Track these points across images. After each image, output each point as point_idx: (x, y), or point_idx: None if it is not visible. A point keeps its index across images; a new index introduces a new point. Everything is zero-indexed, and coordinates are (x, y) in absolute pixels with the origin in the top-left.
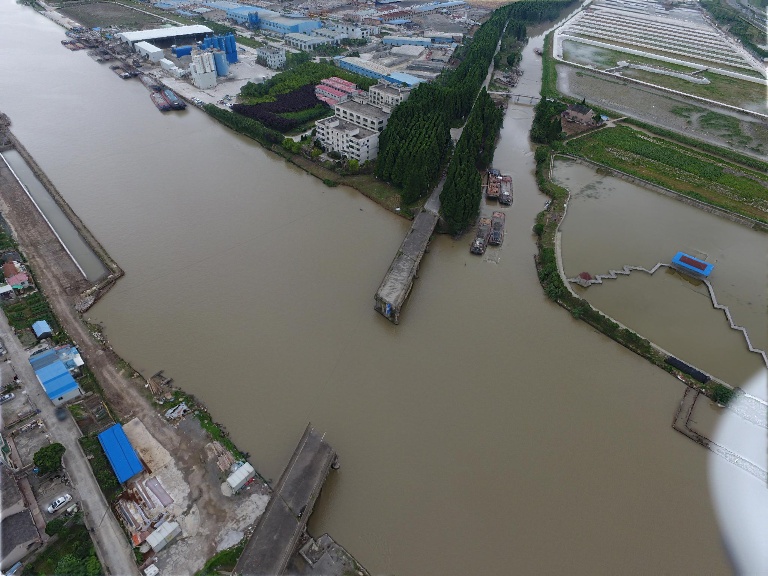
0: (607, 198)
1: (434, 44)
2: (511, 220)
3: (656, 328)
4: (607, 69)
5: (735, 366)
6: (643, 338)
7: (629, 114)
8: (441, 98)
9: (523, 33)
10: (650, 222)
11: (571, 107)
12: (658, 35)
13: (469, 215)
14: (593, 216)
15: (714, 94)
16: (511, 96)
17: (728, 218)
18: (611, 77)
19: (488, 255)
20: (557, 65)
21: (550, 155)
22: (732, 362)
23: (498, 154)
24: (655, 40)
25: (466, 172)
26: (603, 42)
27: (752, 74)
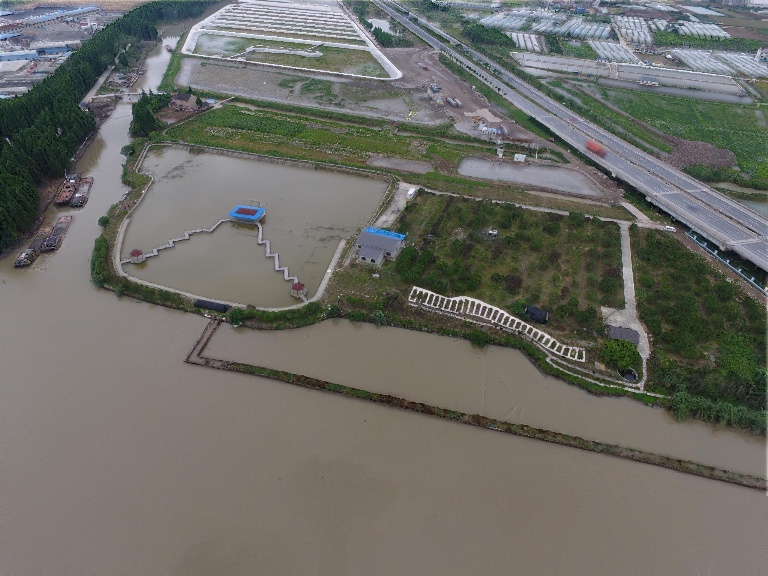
0: (192, 174)
1: (42, 56)
2: (78, 221)
3: (200, 279)
4: (232, 56)
5: (261, 288)
6: (181, 292)
7: (240, 93)
8: (1, 112)
9: (152, 32)
10: (220, 186)
11: (175, 96)
12: (293, 20)
13: (15, 229)
14: (167, 194)
15: (322, 64)
16: (122, 97)
17: (297, 165)
18: (234, 63)
19: (35, 264)
20: (184, 59)
21: (143, 147)
22: (259, 285)
23: (104, 157)
24: (288, 25)
25: (2, 185)
26: (239, 32)
27: (358, 43)
